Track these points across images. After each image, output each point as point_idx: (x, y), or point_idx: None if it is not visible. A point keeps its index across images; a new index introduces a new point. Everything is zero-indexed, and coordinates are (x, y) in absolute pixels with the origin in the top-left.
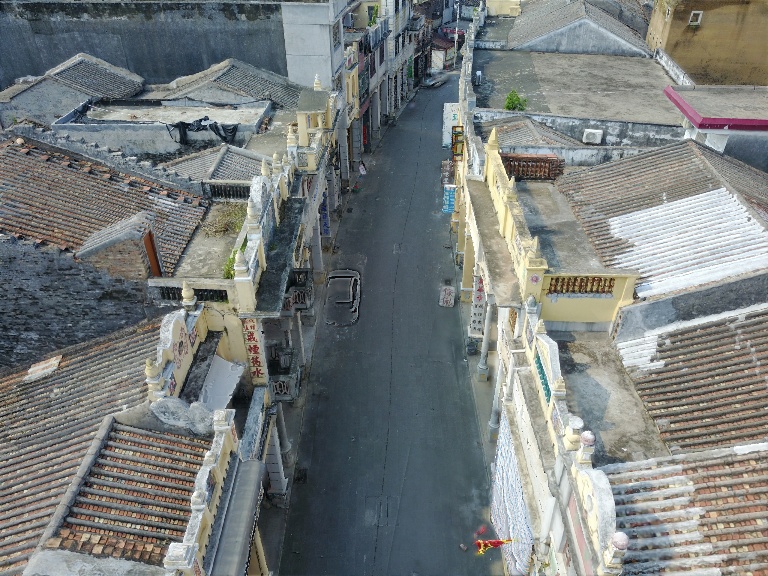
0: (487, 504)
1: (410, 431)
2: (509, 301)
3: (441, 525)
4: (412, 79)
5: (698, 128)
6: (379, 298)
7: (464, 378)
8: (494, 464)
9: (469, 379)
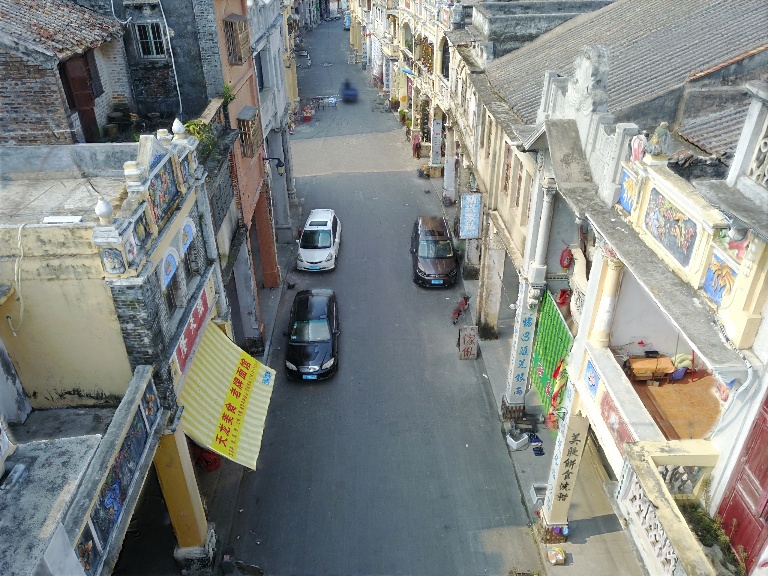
0: None
1: None
2: None
3: None
4: None
5: None
6: None
7: (361, 74)
8: None
9: None
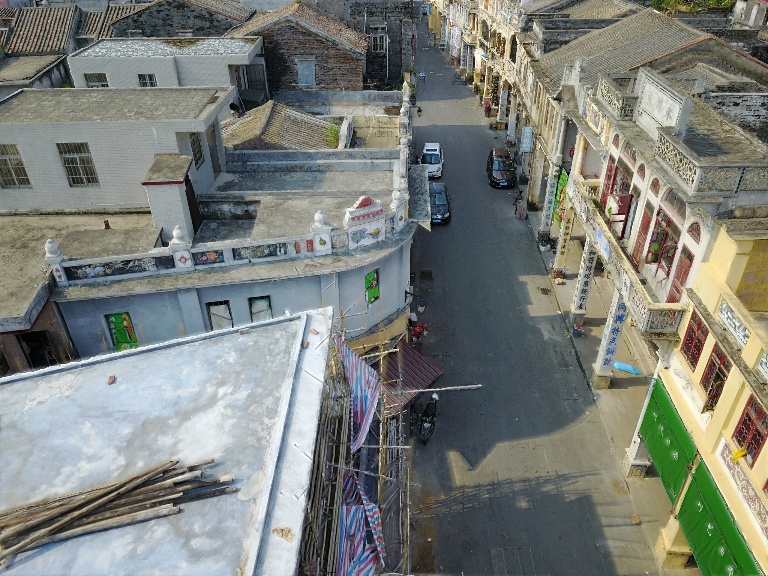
0: None
1: (424, 60)
2: None
3: None
4: None
5: None
6: None
7: (440, 54)
8: None
9: (442, 54)
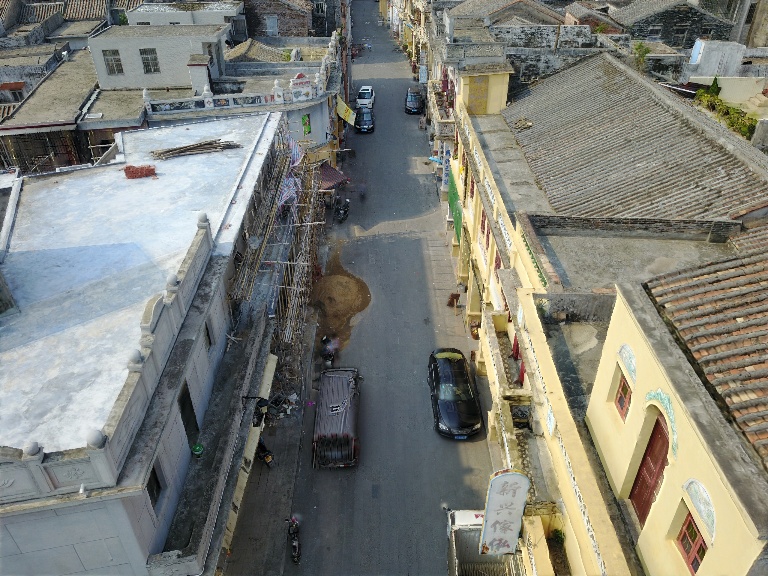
0: None
1: None
2: None
3: None
4: None
5: None
6: None
7: None
8: None
9: None
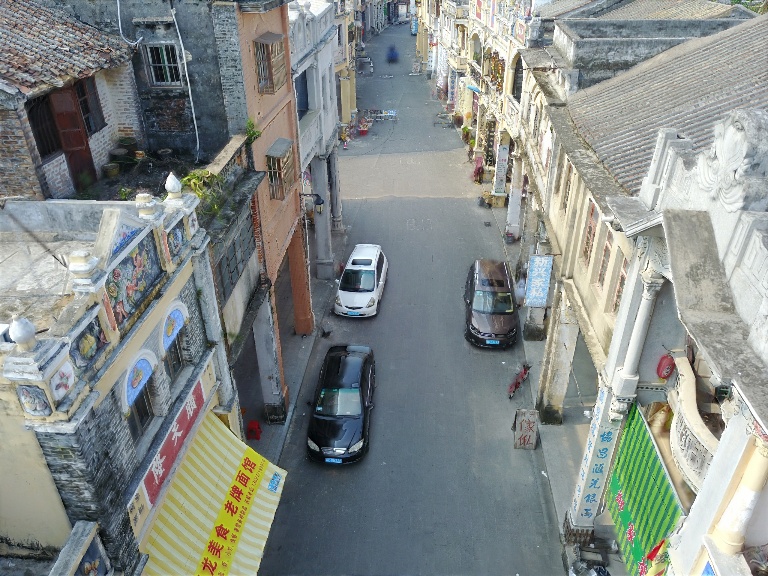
0: None
1: (402, 91)
2: None
3: None
4: None
5: None
6: (382, 72)
7: None
8: None
9: None
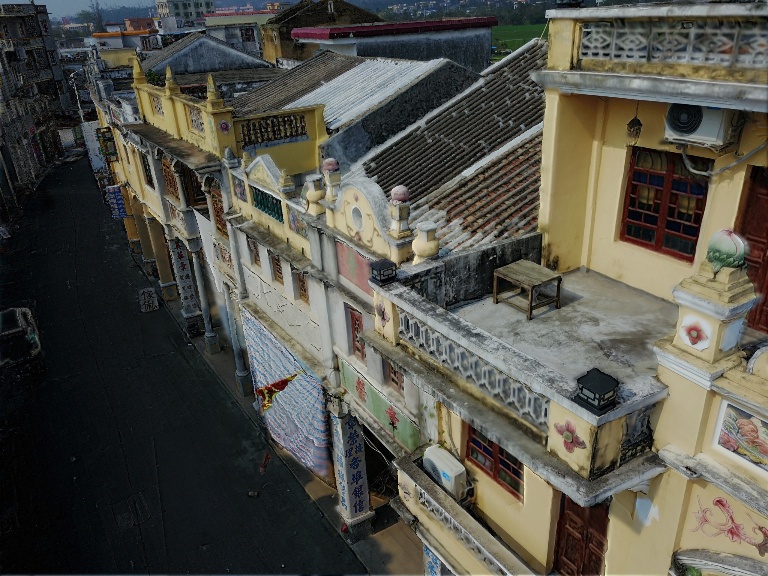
0: (264, 448)
1: (147, 423)
2: (205, 163)
3: (219, 487)
4: (42, 154)
5: (329, 38)
6: (64, 328)
7: (194, 358)
8: (256, 400)
9: (200, 357)
